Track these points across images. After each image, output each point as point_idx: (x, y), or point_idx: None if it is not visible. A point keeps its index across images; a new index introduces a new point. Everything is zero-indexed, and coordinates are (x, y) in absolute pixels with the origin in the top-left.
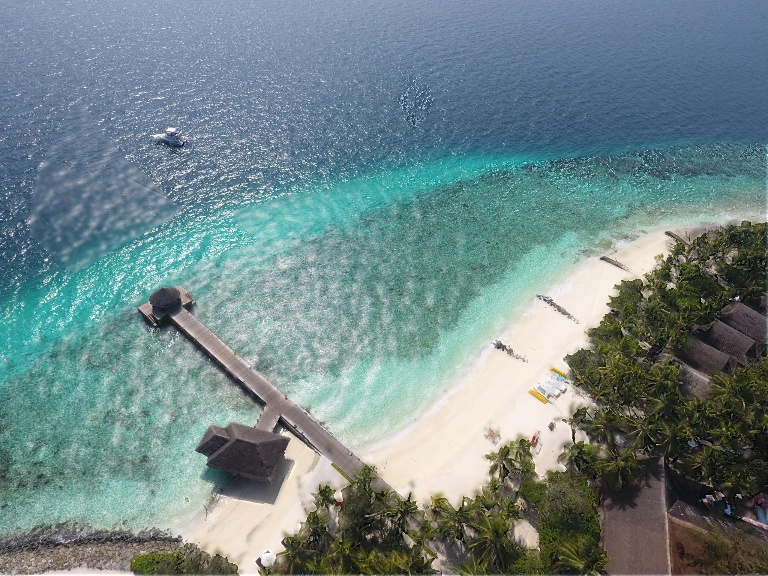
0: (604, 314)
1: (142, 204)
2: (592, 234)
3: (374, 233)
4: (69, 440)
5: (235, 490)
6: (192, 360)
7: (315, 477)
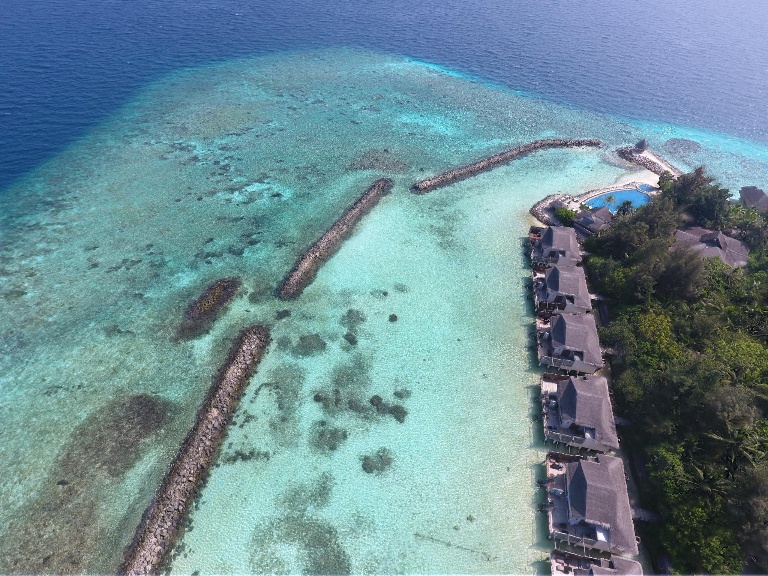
0: None
1: None
2: None
3: None
4: (707, 166)
5: None
6: None
7: None
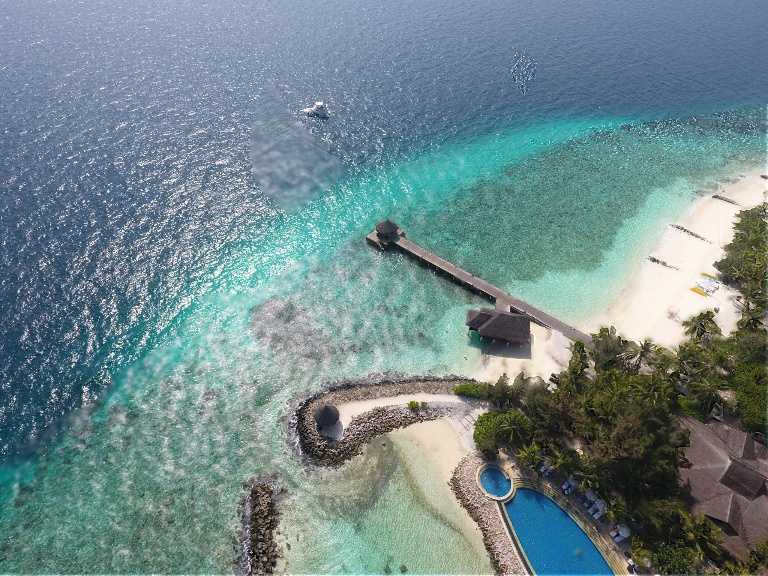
0: (730, 236)
1: (324, 163)
2: (699, 179)
3: (518, 182)
4: (360, 324)
5: (498, 352)
6: (421, 273)
7: (555, 342)
